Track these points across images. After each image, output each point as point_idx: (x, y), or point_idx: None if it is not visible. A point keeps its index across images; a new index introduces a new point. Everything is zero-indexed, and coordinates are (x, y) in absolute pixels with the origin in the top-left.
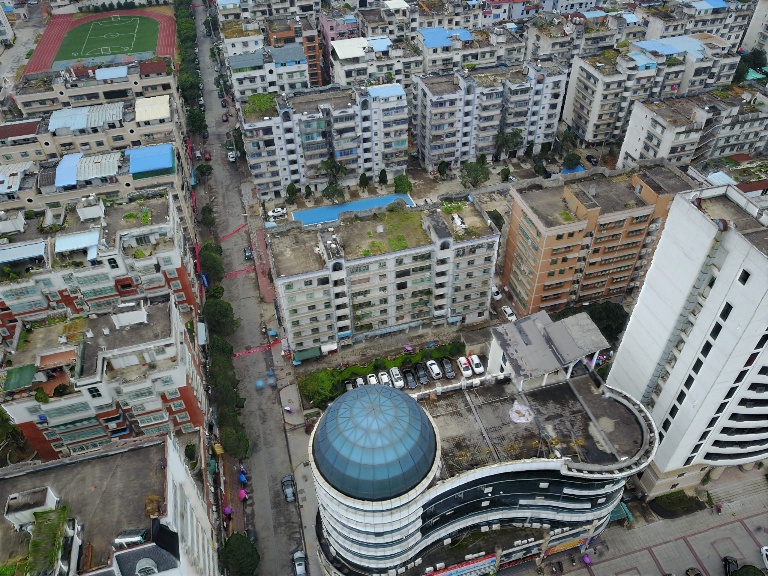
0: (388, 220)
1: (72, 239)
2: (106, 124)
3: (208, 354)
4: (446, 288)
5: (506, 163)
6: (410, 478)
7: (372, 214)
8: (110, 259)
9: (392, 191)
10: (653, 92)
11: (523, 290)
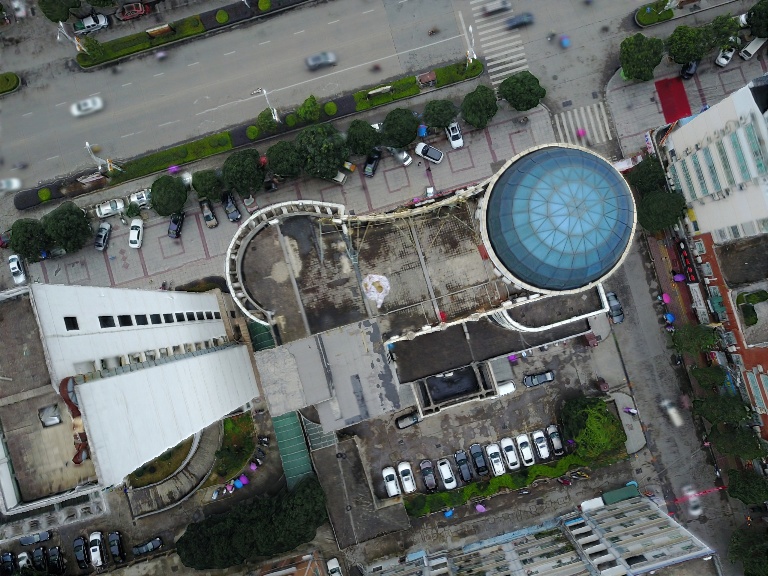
0: None
1: None
2: None
3: (766, 478)
4: None
5: None
6: (520, 164)
7: None
8: None
9: None
10: None
11: None
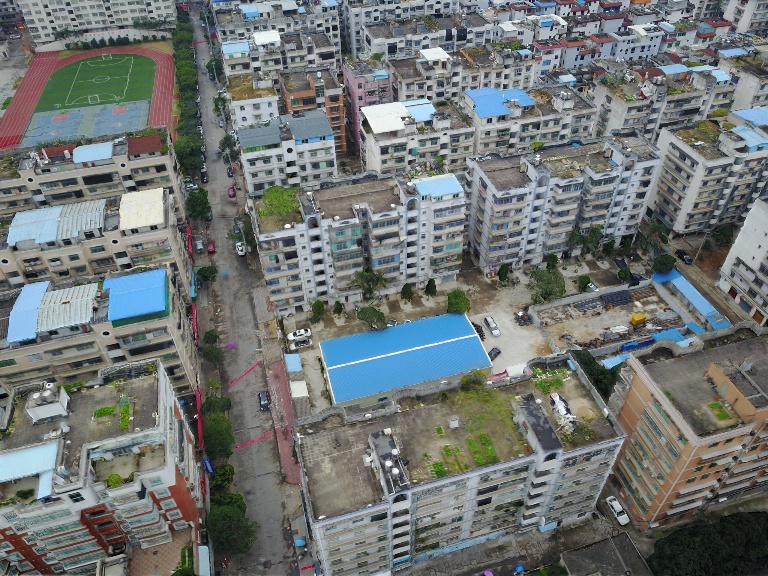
0: (465, 410)
1: (18, 458)
2: (82, 233)
3: None
4: (543, 497)
5: (579, 261)
6: None
7: (439, 391)
8: (72, 493)
9: (441, 302)
10: (762, 176)
11: (644, 491)
